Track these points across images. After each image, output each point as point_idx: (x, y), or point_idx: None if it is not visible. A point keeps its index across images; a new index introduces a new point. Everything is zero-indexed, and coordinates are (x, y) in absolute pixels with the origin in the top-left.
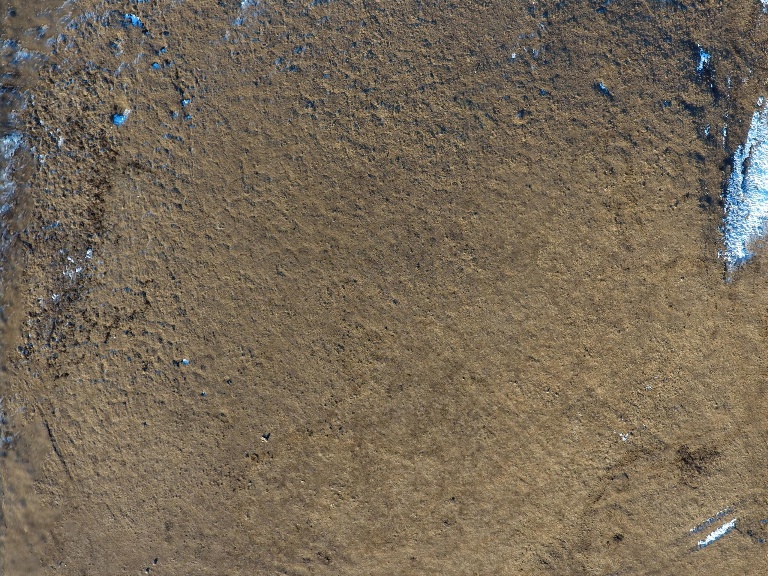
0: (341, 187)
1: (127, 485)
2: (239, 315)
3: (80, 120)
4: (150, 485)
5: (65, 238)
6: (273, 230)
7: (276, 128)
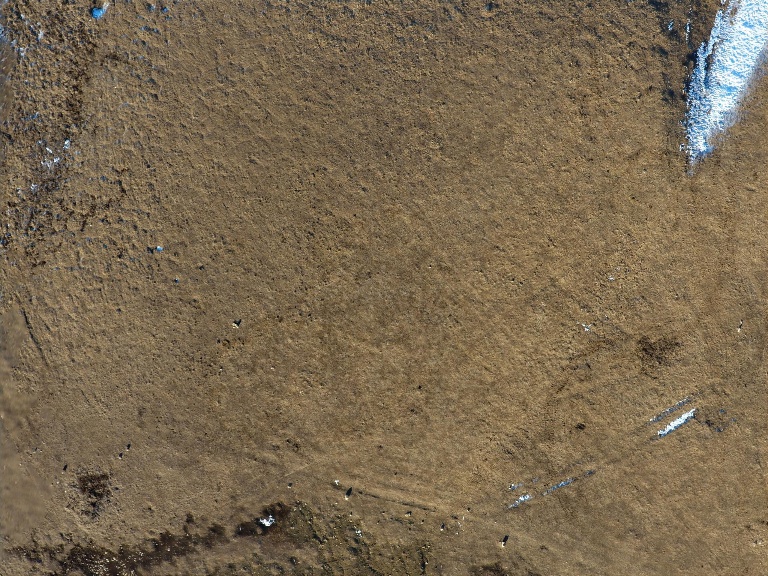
0: (313, 77)
1: (101, 371)
2: (212, 202)
3: (60, 13)
4: (124, 371)
5: (44, 129)
6: (246, 119)
7: (250, 20)
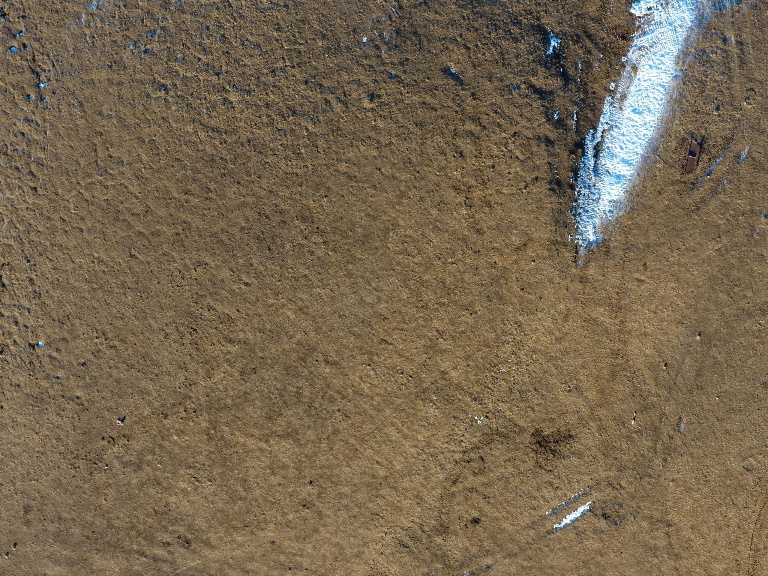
0: (193, 170)
1: None
2: (93, 298)
3: None
4: (8, 469)
5: None
6: (126, 213)
7: (130, 111)
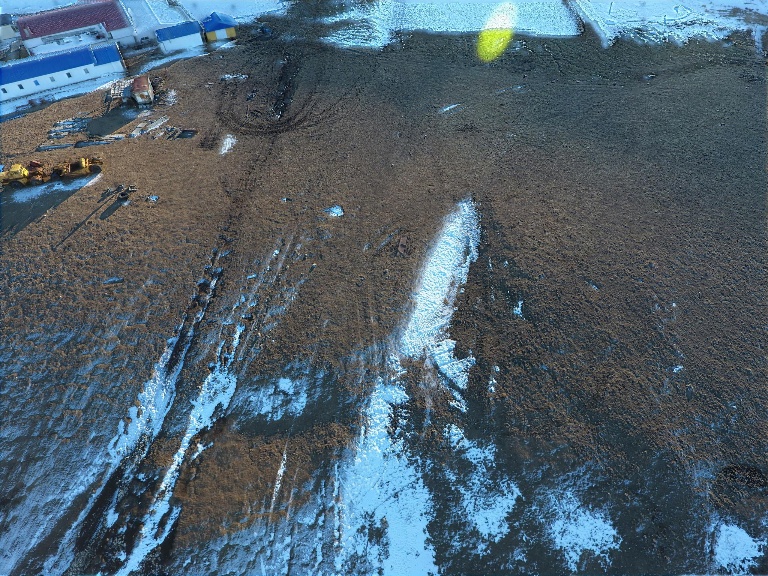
0: (759, 223)
1: None
2: None
3: None
4: None
5: None
6: None
7: None
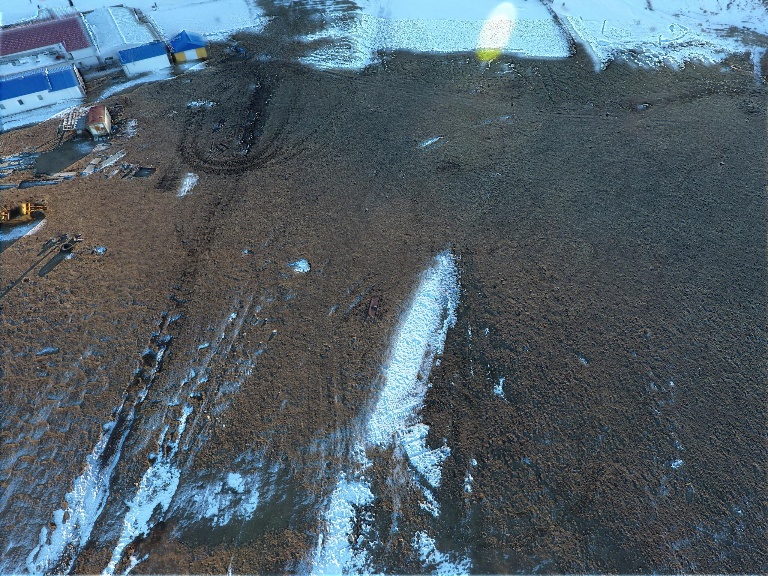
0: (763, 283)
1: None
2: None
3: None
4: None
5: None
6: None
7: None
